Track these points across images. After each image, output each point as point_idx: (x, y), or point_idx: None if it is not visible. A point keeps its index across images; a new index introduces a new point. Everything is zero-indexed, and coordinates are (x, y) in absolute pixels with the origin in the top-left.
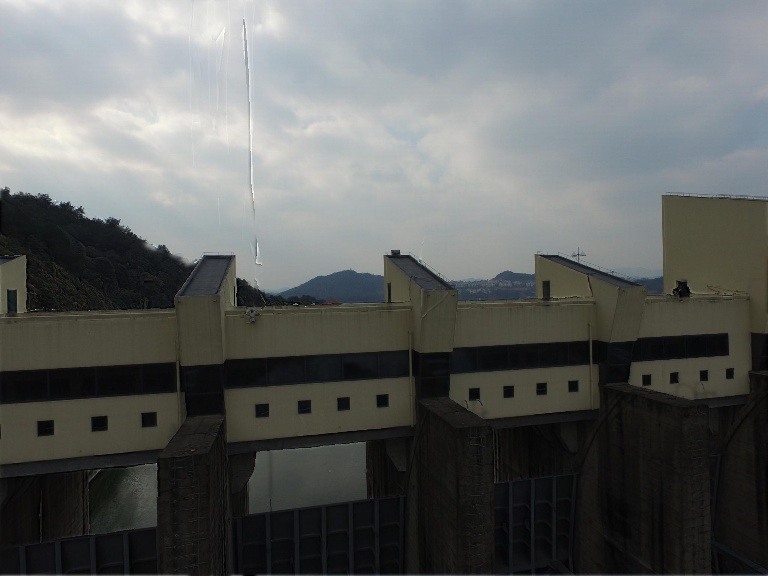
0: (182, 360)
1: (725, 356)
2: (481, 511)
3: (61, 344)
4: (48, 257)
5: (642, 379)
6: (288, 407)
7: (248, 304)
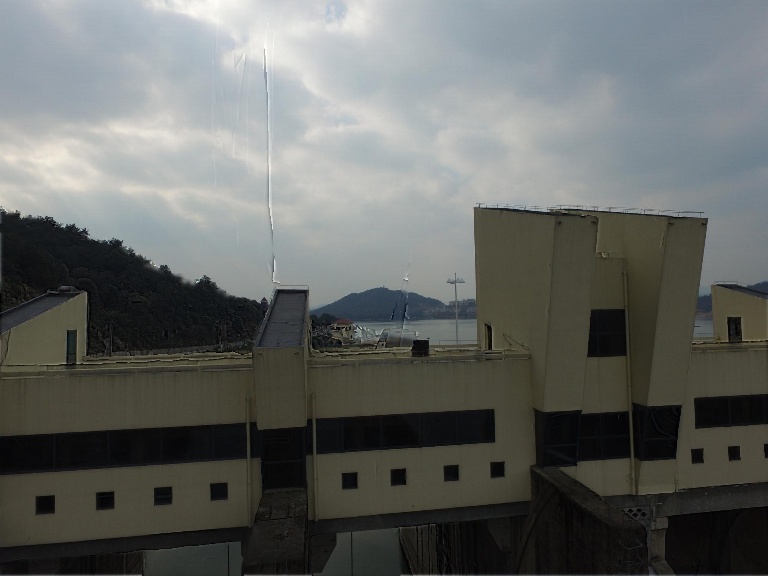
0: None
1: (489, 443)
2: None
3: None
4: (20, 279)
5: (341, 479)
6: None
7: (248, 324)
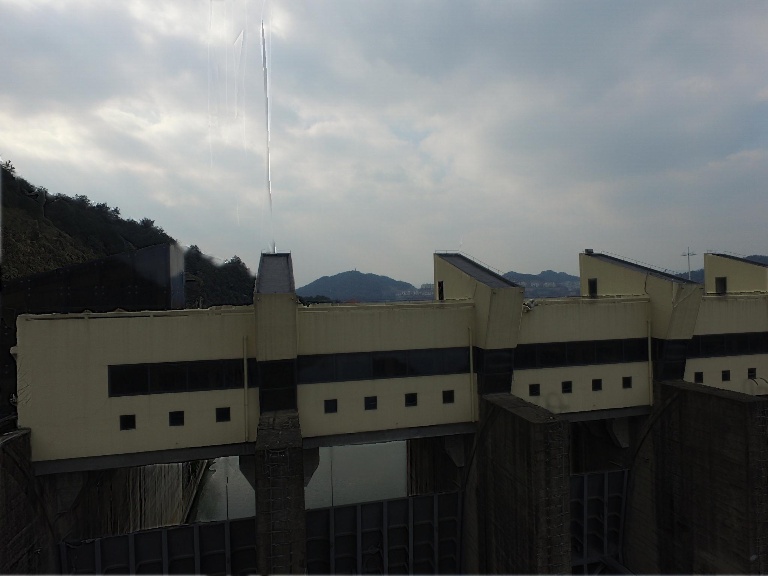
0: (486, 344)
1: None
2: (766, 474)
3: (381, 330)
4: None
5: None
6: (554, 387)
7: None
